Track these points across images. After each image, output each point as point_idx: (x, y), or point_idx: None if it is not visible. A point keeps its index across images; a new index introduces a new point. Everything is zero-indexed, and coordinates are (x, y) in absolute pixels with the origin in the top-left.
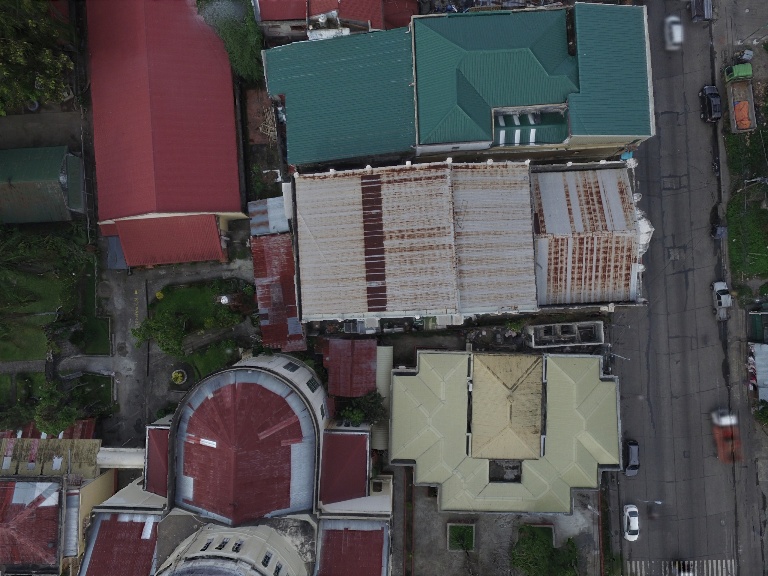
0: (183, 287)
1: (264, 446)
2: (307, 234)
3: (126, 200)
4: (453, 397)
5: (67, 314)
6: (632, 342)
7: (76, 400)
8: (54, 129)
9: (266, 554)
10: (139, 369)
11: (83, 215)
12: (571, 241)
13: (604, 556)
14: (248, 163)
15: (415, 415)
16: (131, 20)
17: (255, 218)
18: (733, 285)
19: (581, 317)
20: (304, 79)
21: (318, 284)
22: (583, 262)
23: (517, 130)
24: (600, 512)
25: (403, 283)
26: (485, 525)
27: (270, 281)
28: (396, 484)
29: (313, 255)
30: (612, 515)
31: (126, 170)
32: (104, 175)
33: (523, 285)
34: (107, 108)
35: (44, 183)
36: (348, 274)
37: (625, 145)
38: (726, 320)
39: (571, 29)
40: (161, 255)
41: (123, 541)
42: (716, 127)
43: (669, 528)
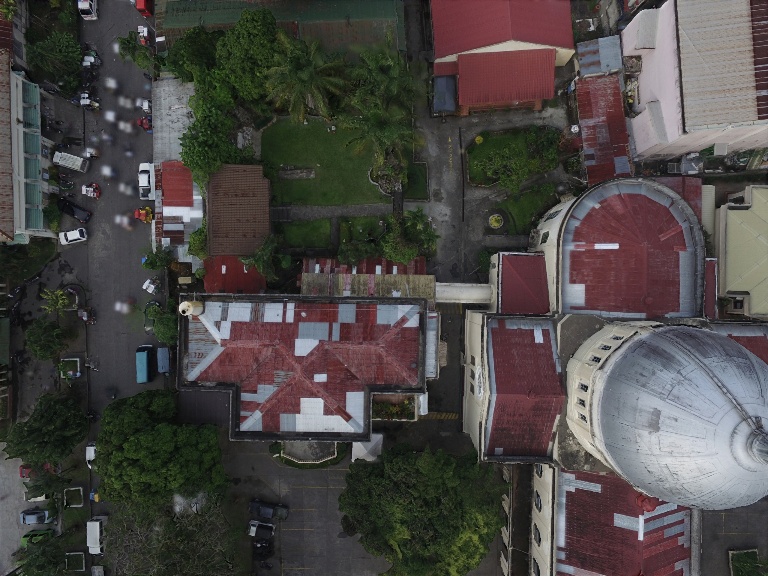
0: (496, 134)
1: (664, 248)
2: (690, 48)
3: (472, 34)
4: None
5: None
6: None
7: (409, 237)
8: None
9: None
10: (455, 214)
11: None
12: None
13: None
14: None
15: (753, 245)
16: None
17: (585, 58)
18: None
19: None
20: None
21: (703, 96)
22: None
23: None
24: None
25: None
26: None
27: (596, 122)
28: None
29: (697, 68)
30: None
31: (472, 4)
32: (443, 12)
33: None
34: None
35: (381, 21)
36: (736, 85)
37: None
38: None
39: None
40: (494, 94)
41: (519, 344)
42: None
43: None
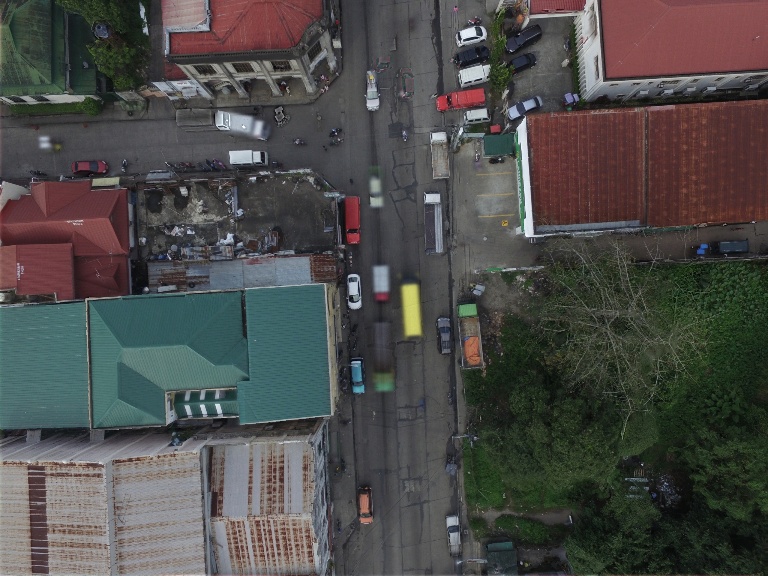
0: None
1: None
2: None
3: None
4: None
5: None
6: (367, 574)
7: None
8: None
9: None
10: None
11: None
12: (247, 523)
13: None
14: None
15: None
16: None
17: None
18: (468, 517)
19: None
20: None
21: None
22: (263, 541)
23: (201, 405)
24: None
25: None
26: None
27: None
28: None
29: None
30: None
31: None
32: None
33: (192, 574)
34: None
35: None
36: (16, 563)
37: None
38: (459, 554)
39: None
40: None
41: None
42: (454, 356)
43: None
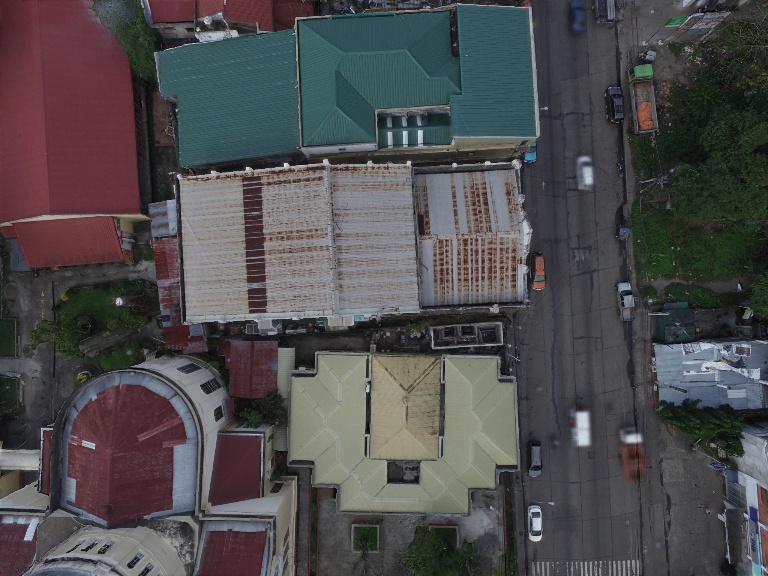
0: (89, 289)
1: (144, 448)
2: (191, 236)
3: (23, 202)
4: (350, 398)
5: None
6: (537, 343)
7: None
8: None
9: (136, 556)
10: (45, 371)
11: None
12: (455, 242)
13: (508, 557)
14: (154, 165)
15: (312, 416)
16: (26, 22)
17: (155, 220)
18: (638, 286)
19: (482, 318)
20: (195, 81)
21: (201, 286)
22: (469, 263)
23: (404, 131)
24: (505, 513)
25: (282, 285)
26: (390, 526)
27: (172, 283)
28: (301, 485)
29: (196, 257)
30: (517, 516)
31: (23, 172)
32: (3, 177)
33: (405, 286)
34: (5, 110)
35: None
36: (230, 276)
37: (516, 146)
38: (630, 321)
39: (455, 30)
40: (61, 257)
41: (5, 543)
42: (622, 128)
43: (574, 529)
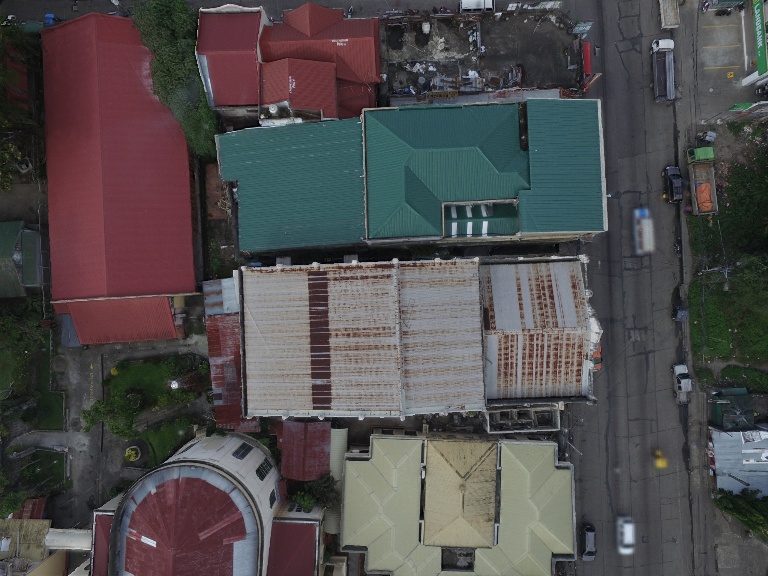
0: (139, 362)
1: (205, 546)
2: (254, 328)
3: (78, 281)
4: (406, 484)
5: (19, 392)
6: (591, 424)
7: (27, 479)
8: (12, 201)
9: None
10: (93, 445)
11: (39, 288)
12: (521, 337)
13: None
14: (206, 238)
15: (367, 502)
16: (85, 101)
17: (209, 298)
18: (694, 368)
19: None
20: (256, 165)
21: (264, 379)
22: (534, 358)
23: (469, 222)
24: None
25: (348, 382)
26: None
27: (224, 361)
28: (350, 565)
29: (259, 350)
30: None
31: (79, 251)
32: (57, 254)
33: (471, 384)
34: (61, 187)
35: None
36: (294, 370)
37: (580, 236)
38: (686, 404)
39: (523, 123)
40: (114, 334)
41: None
42: (679, 207)
43: None
